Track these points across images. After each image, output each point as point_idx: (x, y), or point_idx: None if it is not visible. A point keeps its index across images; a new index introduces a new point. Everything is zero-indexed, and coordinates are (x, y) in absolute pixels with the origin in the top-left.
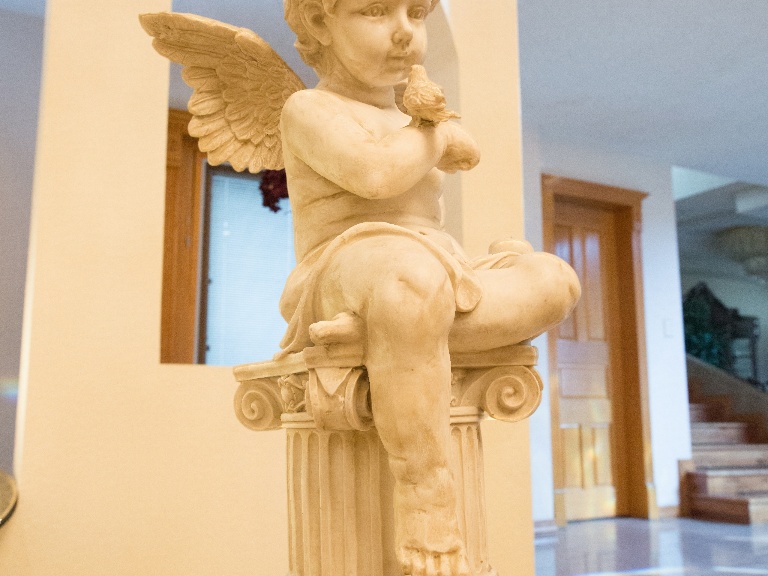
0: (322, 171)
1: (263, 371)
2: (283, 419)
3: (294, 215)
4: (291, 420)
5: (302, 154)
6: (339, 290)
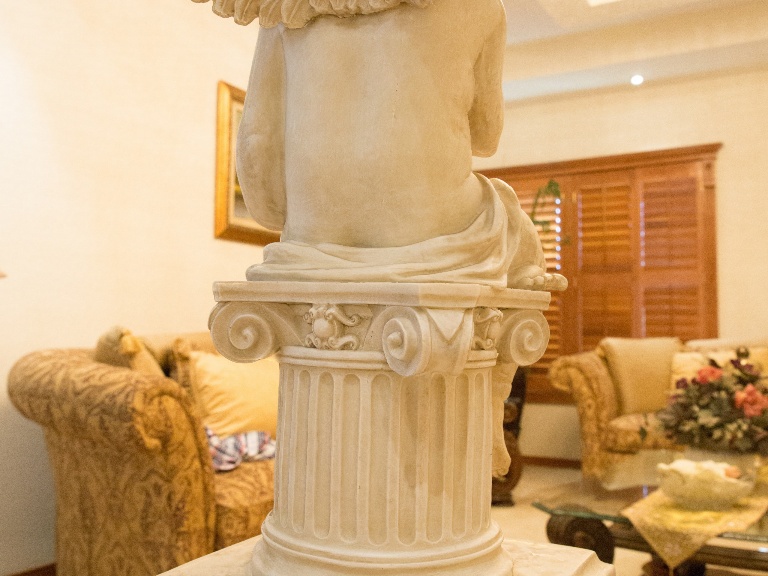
0: (495, 103)
1: (483, 298)
2: (485, 357)
3: (459, 109)
4: (494, 357)
5: (493, 67)
6: (535, 245)
